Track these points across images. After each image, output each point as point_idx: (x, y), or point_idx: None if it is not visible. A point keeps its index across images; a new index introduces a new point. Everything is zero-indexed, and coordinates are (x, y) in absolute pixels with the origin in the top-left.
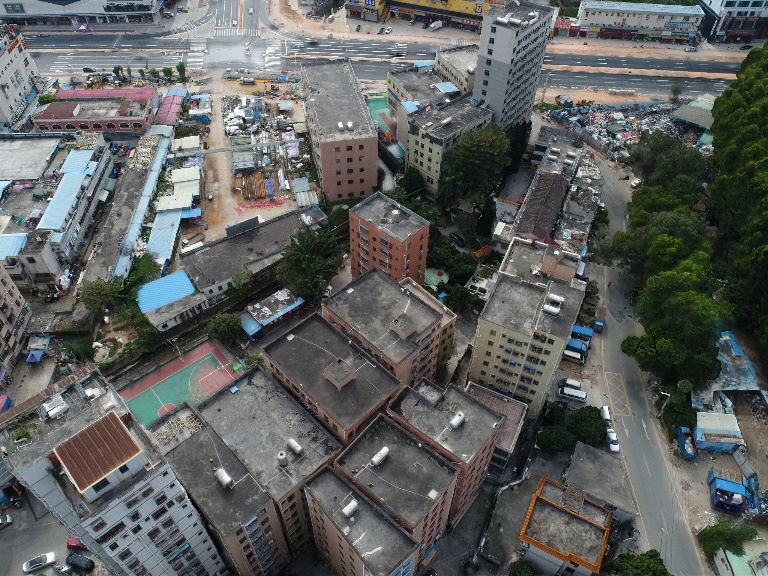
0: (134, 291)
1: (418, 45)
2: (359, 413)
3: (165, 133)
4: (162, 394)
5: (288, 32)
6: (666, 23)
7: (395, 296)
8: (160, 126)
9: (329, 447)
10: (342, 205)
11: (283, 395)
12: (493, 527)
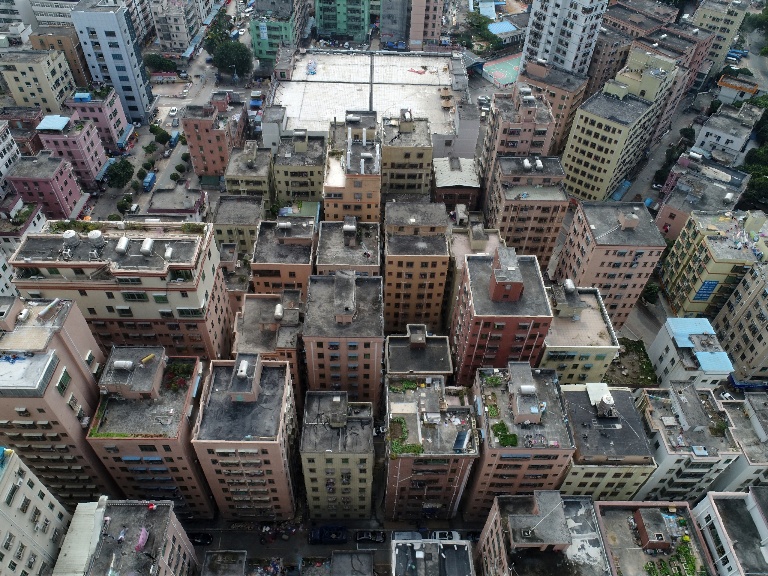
0: (485, 25)
1: None
2: None
3: None
4: (512, 63)
5: None
6: None
7: (653, 4)
8: None
9: None
10: None
11: (607, 29)
12: (696, 102)
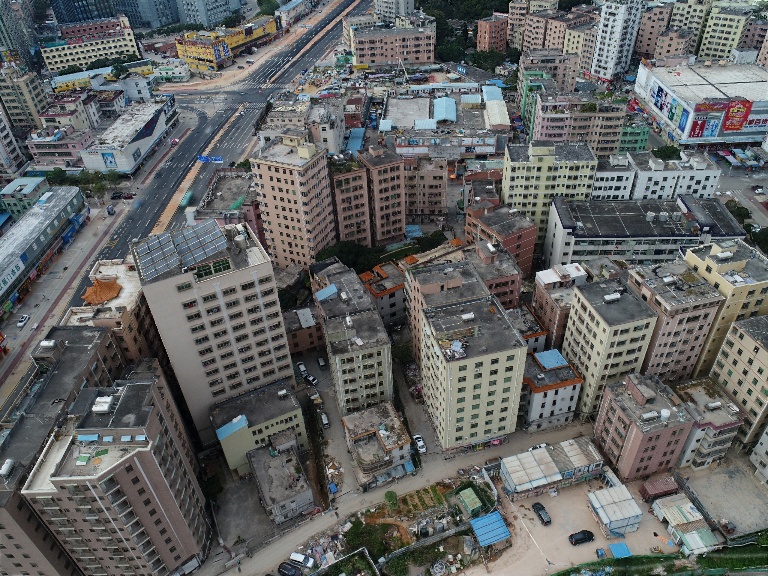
0: None
1: (277, 55)
2: None
3: None
4: None
5: (231, 84)
6: (304, 6)
7: None
8: None
9: None
10: None
11: None
12: None
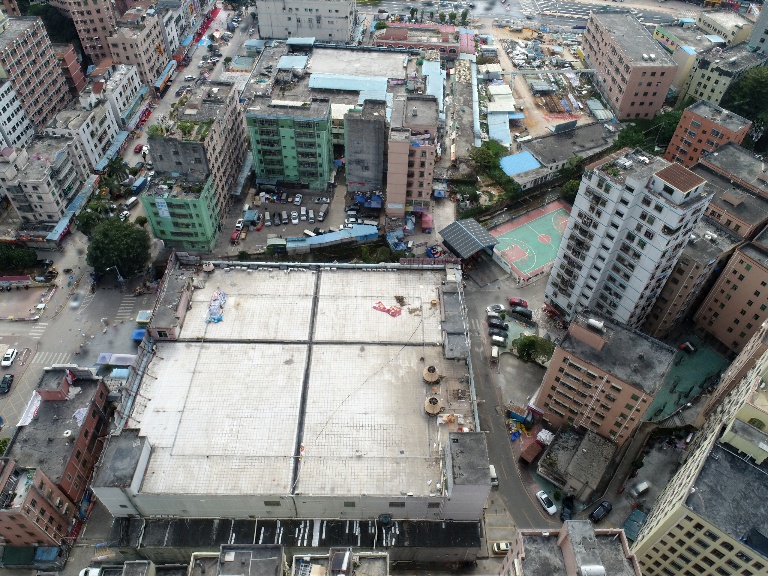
0: (497, 161)
1: (652, 12)
2: (755, 220)
3: (472, 59)
4: (536, 228)
5: None
6: None
7: (751, 160)
8: (466, 54)
9: (733, 240)
10: (629, 123)
11: None
12: None
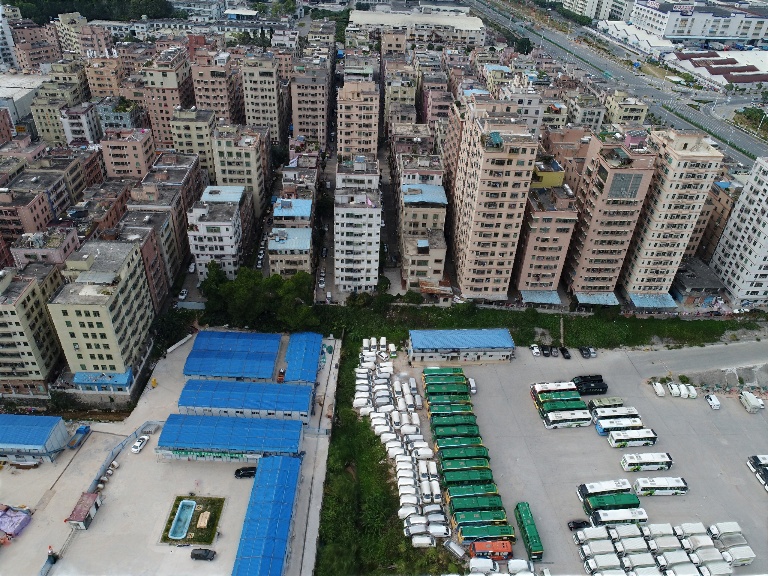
0: None
1: None
2: None
3: None
4: None
5: None
6: None
7: None
8: None
9: None
10: None
11: None
12: None
